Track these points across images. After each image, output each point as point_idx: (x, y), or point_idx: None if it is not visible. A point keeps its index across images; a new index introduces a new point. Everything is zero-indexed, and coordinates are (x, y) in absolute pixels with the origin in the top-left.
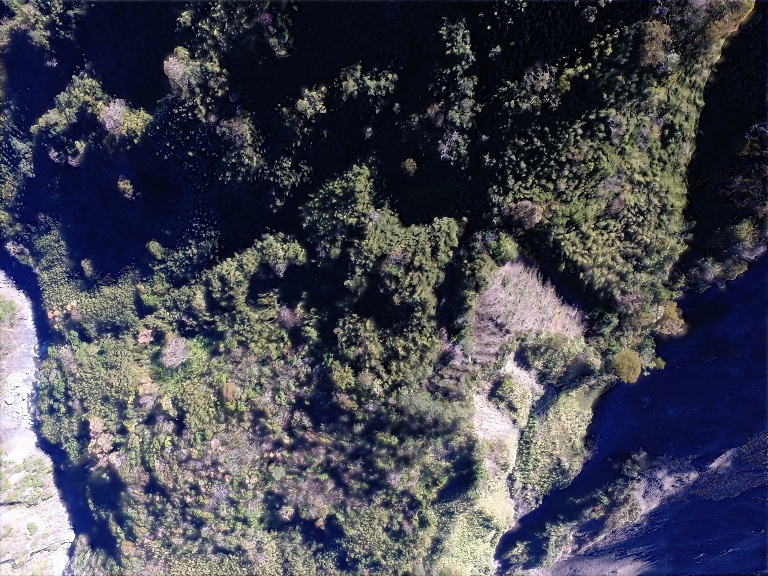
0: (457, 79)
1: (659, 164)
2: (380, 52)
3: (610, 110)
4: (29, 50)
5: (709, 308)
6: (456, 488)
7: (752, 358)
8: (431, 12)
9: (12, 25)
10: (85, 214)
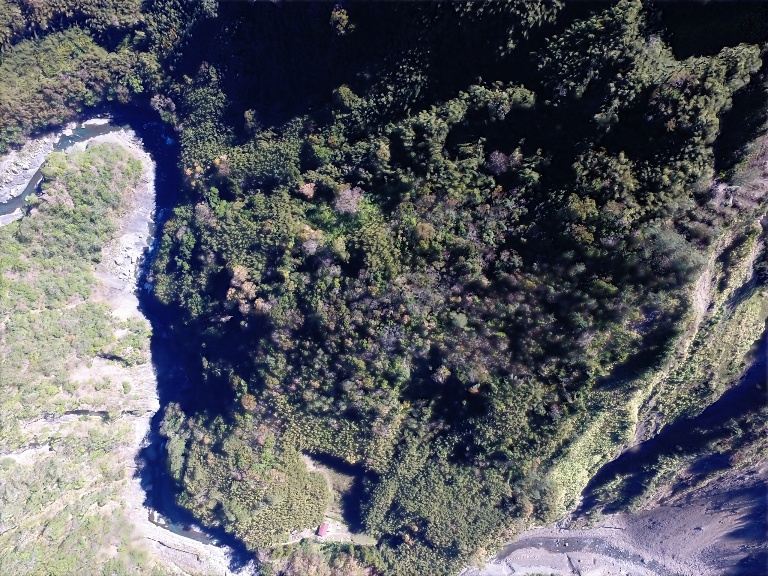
0: None
1: None
2: None
3: None
4: None
5: None
6: (626, 373)
7: None
8: None
9: None
10: (253, 67)
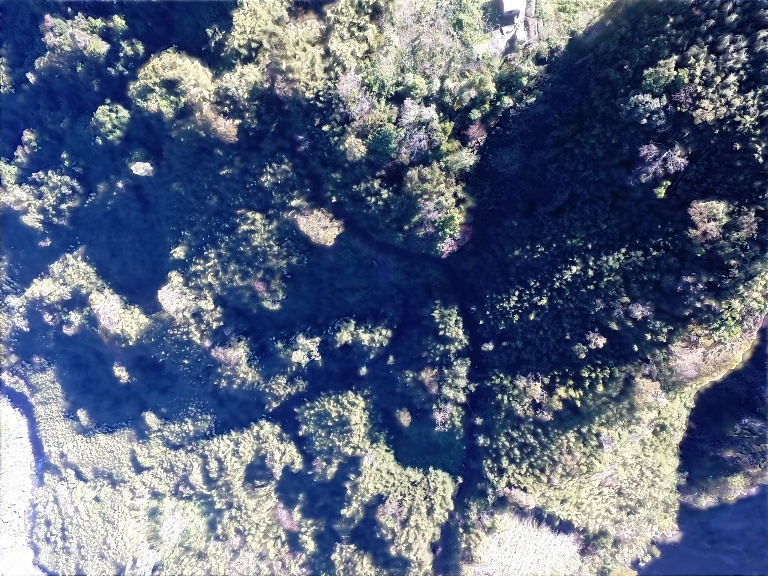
0: (450, 357)
1: (651, 447)
2: (374, 309)
3: (602, 429)
4: (22, 221)
5: None
6: None
7: (746, 552)
8: (424, 282)
9: (5, 201)
10: (80, 360)
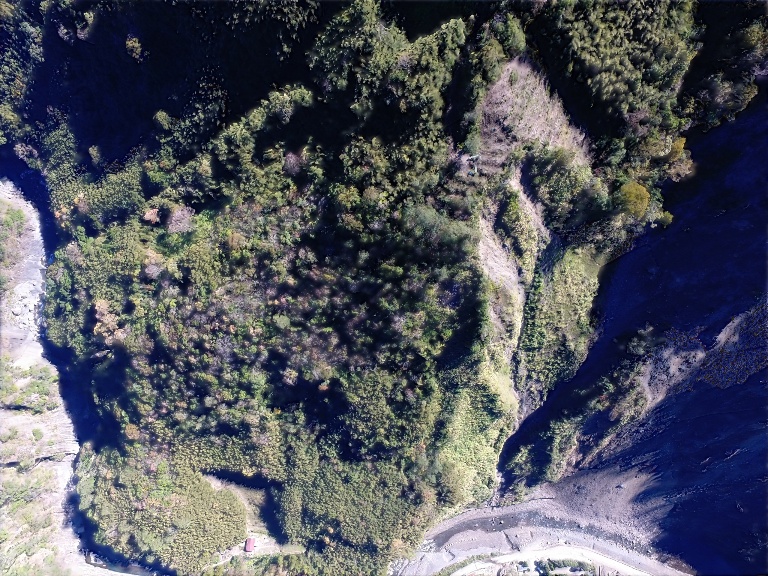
0: None
1: None
2: None
3: None
4: None
5: (718, 156)
6: (460, 348)
7: (761, 207)
8: None
9: None
10: (93, 104)
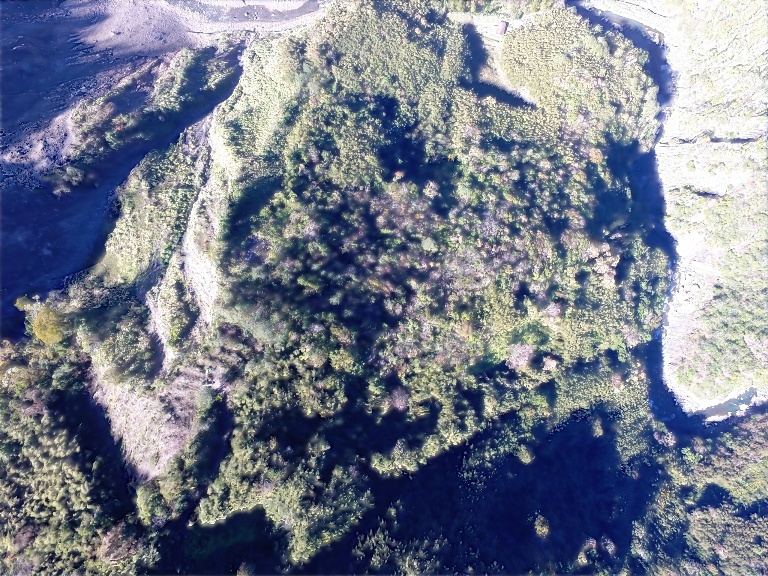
0: None
1: None
2: None
3: None
4: None
5: None
6: (255, 196)
7: None
8: None
9: None
10: (594, 477)
